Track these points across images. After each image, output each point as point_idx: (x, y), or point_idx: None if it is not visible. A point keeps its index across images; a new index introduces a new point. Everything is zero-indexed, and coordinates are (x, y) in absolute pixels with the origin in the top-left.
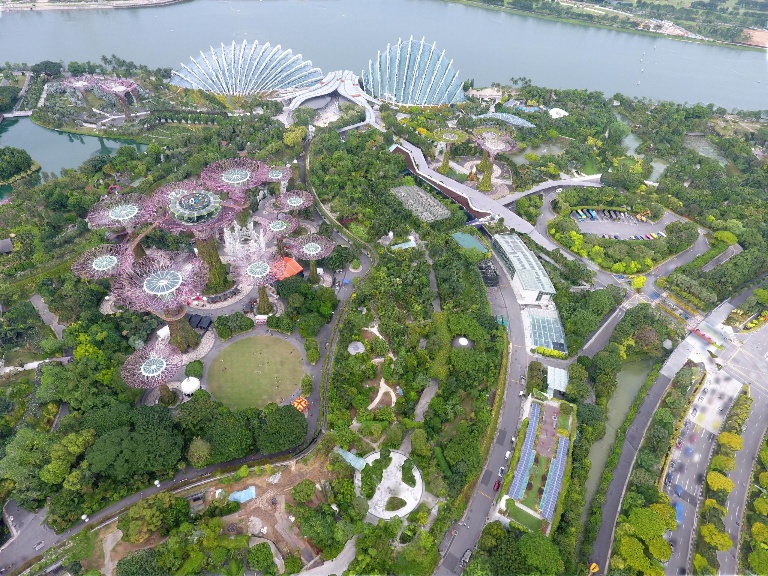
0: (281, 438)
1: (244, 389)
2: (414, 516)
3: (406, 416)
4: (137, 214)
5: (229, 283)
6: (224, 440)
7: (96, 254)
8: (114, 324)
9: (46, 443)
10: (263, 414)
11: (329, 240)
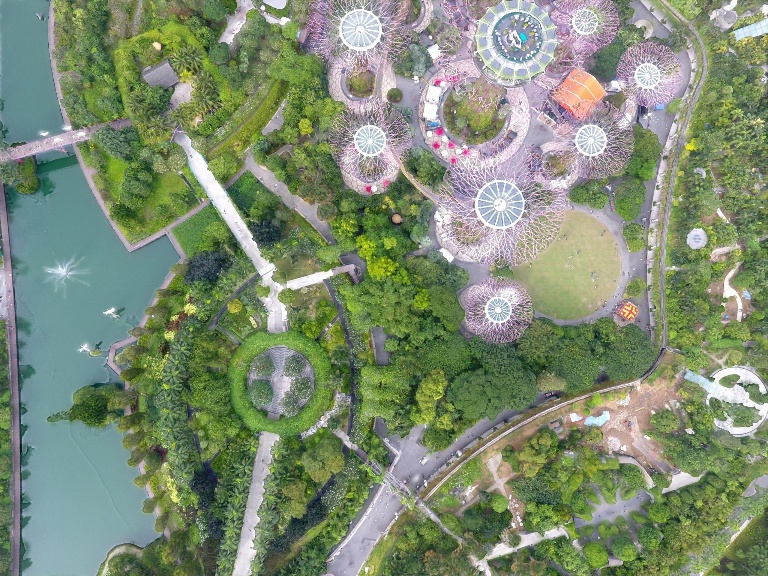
0: (634, 368)
1: (559, 291)
2: (767, 437)
3: (758, 330)
4: (383, 33)
5: (501, 122)
6: (576, 373)
7: (349, 122)
8: (385, 213)
9: (393, 380)
10: (605, 337)
11: (673, 55)
